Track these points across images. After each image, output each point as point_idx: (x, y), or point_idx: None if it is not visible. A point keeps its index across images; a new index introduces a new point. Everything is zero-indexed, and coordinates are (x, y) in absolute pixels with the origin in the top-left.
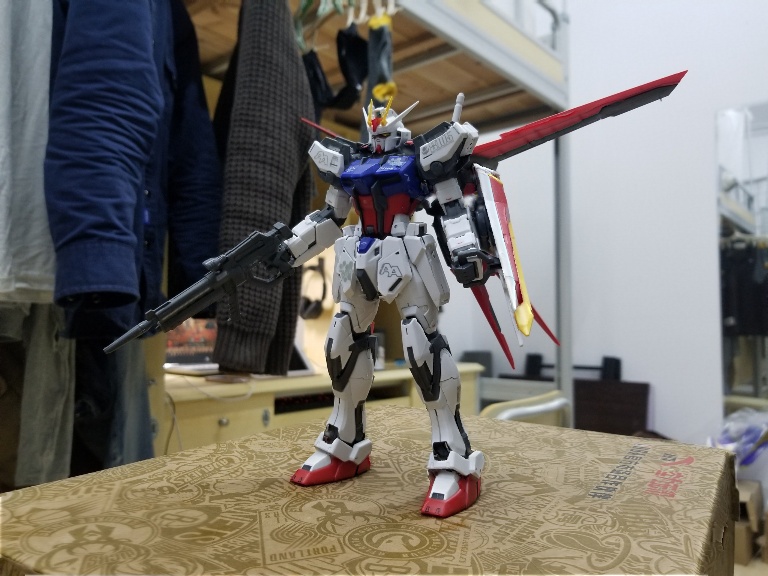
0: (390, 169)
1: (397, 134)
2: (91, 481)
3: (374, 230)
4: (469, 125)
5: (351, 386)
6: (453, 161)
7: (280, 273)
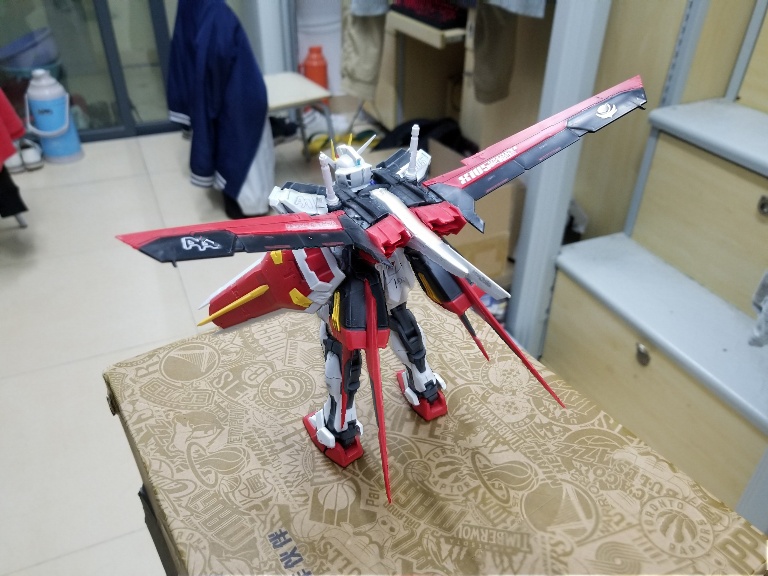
0: None
1: None
2: None
3: None
4: (282, 191)
5: None
6: None
7: None
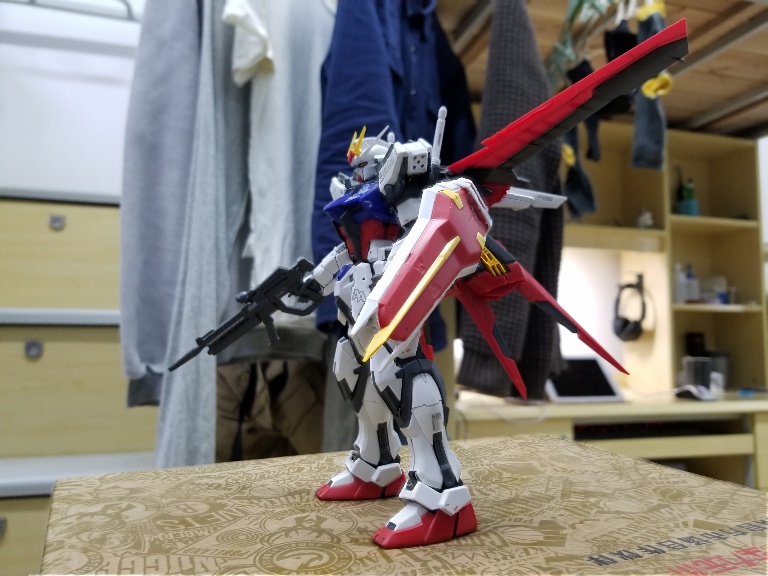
0: (354, 198)
1: (375, 162)
2: (176, 472)
3: (354, 257)
4: (421, 142)
5: (366, 408)
6: (398, 182)
7: (312, 301)
